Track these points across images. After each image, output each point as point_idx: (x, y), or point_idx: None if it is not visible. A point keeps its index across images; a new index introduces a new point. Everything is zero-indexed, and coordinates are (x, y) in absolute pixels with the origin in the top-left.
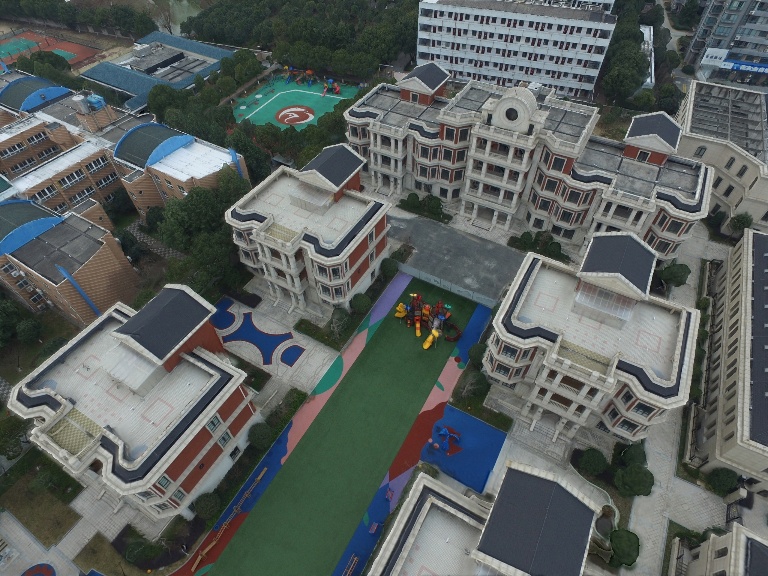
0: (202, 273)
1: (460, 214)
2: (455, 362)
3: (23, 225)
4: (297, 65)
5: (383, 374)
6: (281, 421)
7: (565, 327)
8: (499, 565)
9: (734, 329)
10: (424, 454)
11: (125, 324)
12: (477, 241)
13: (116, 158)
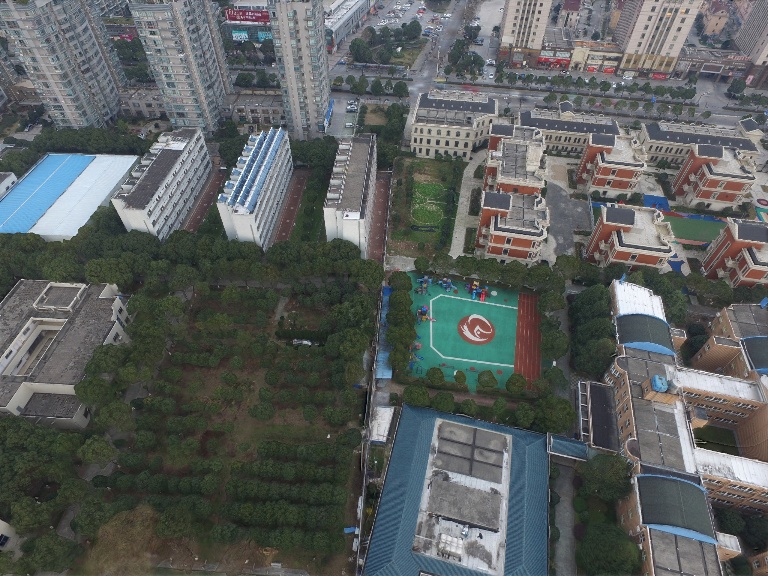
0: (692, 273)
1: None
2: None
3: None
4: None
5: None
6: (701, 246)
7: (629, 156)
8: None
9: None
10: (668, 211)
11: (762, 241)
12: None
13: None
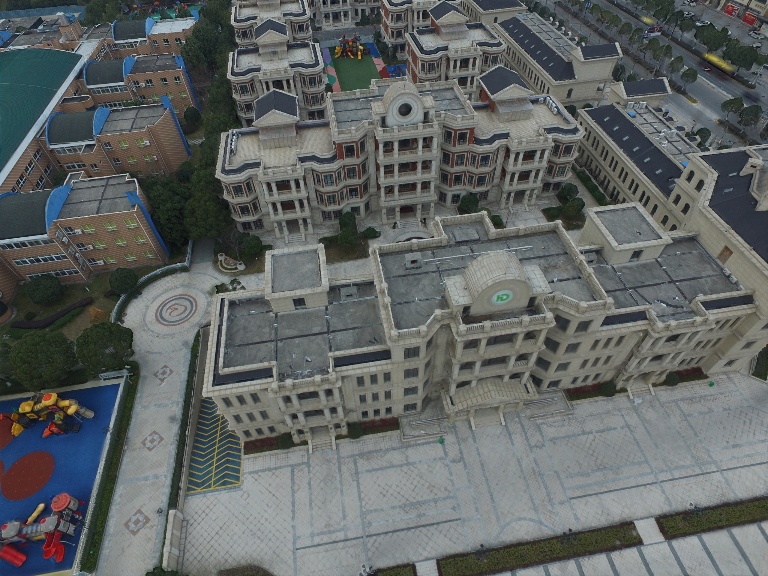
0: None
1: (324, 25)
2: (376, 58)
3: (126, 58)
4: (145, 0)
5: (352, 70)
6: None
7: None
8: (445, 16)
9: (461, 2)
10: None
11: None
12: (342, 30)
13: (117, 41)
